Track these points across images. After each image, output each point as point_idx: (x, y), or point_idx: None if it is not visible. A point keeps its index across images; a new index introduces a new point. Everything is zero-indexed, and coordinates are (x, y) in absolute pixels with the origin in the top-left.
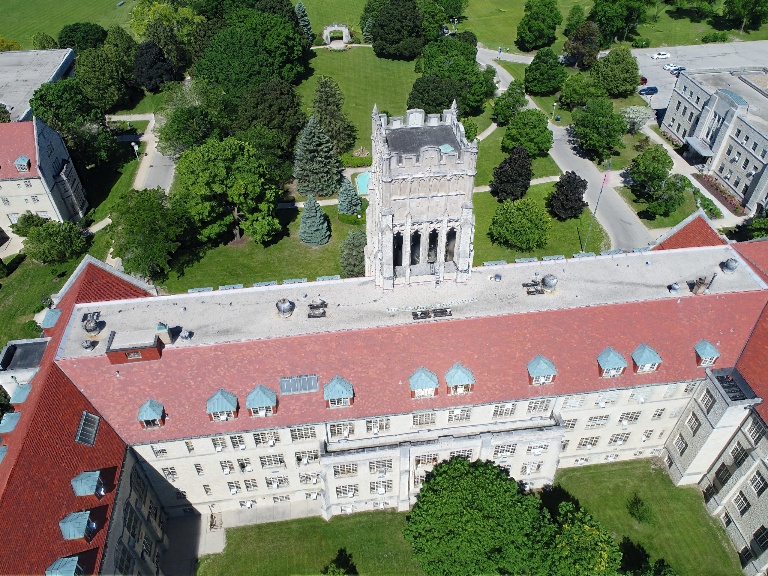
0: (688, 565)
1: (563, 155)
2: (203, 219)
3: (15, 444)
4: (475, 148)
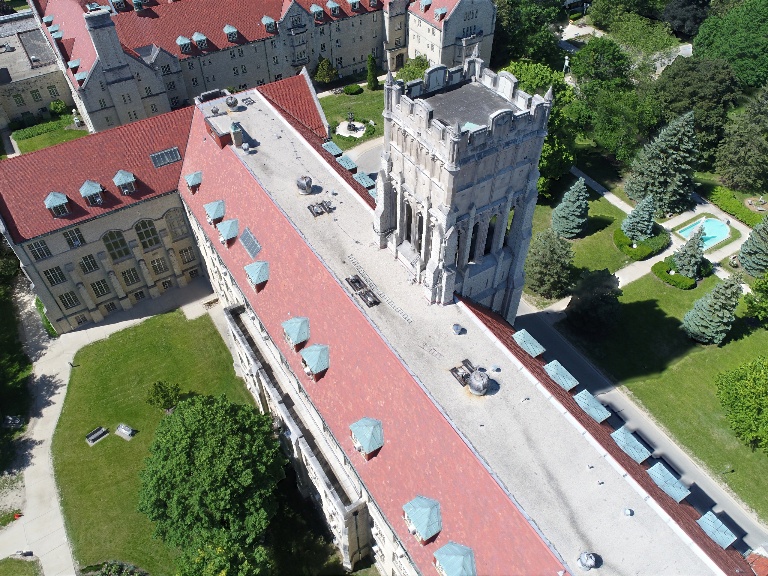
0: None
1: None
2: None
3: None
4: (453, 134)
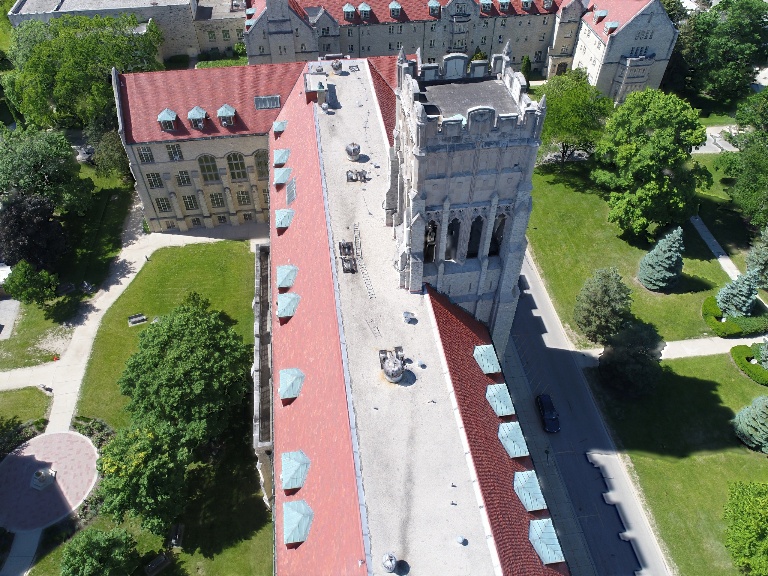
0: None
1: None
2: None
3: None
4: (418, 117)
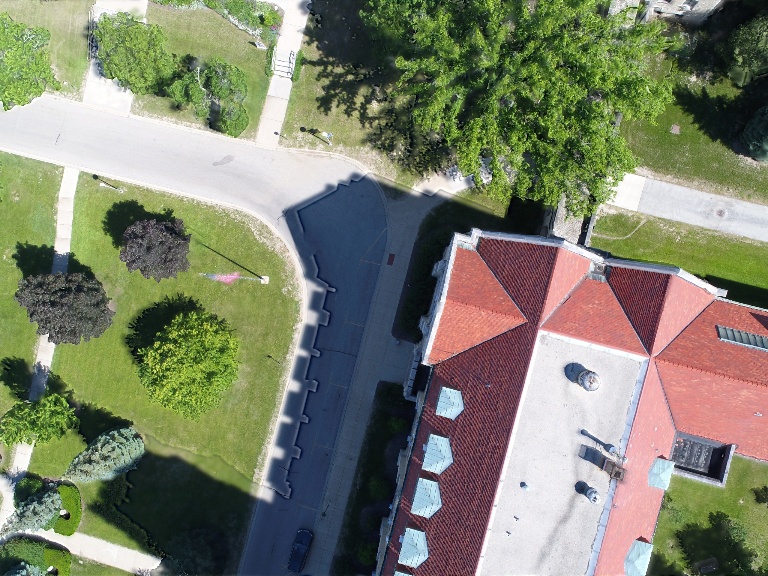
0: (725, 493)
1: (5, 127)
2: None
3: None
4: None
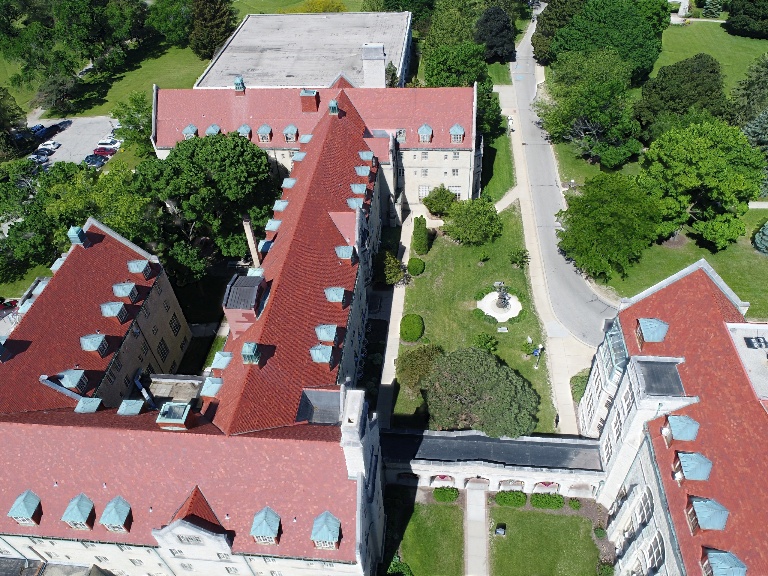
0: None
1: None
2: (669, 215)
3: (763, 509)
4: None
